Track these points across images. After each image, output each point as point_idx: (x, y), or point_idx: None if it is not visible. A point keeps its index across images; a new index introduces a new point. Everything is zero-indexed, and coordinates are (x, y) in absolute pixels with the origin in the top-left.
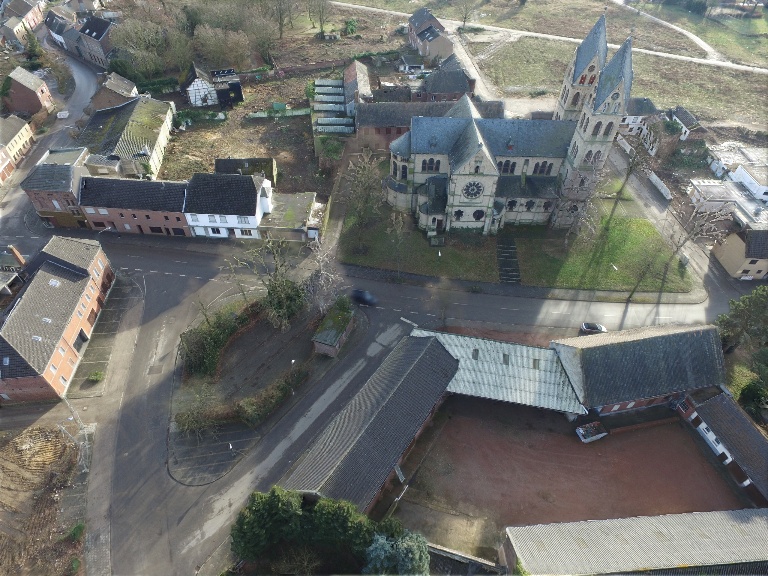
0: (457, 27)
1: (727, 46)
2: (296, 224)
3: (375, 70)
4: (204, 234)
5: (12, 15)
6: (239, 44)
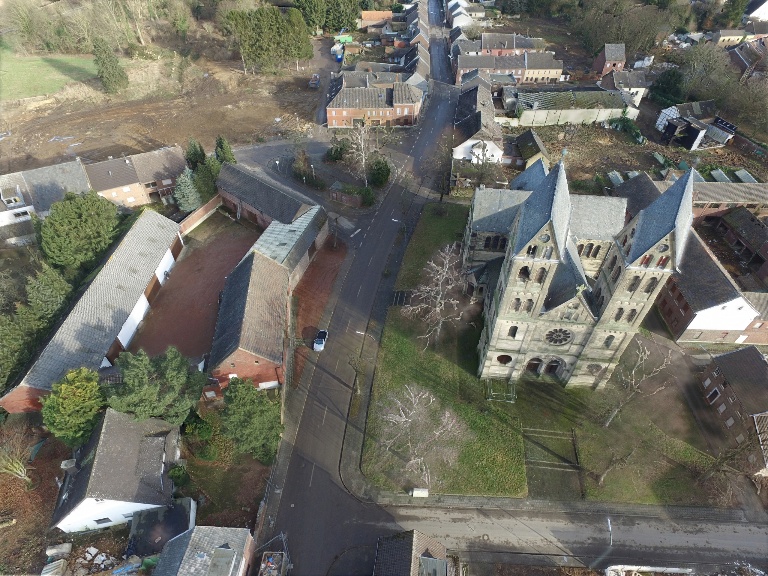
0: None
1: None
2: None
3: None
4: None
5: (750, 30)
6: None
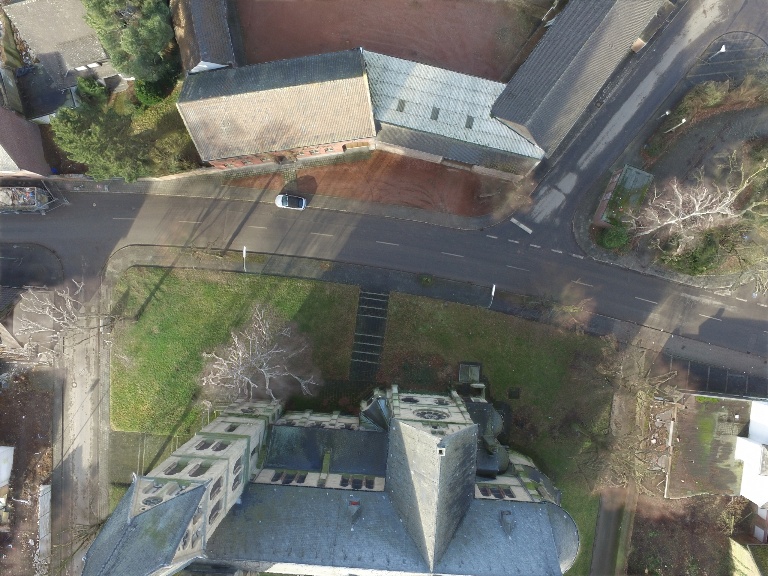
0: None
1: None
2: (694, 406)
3: None
4: None
5: None
6: None
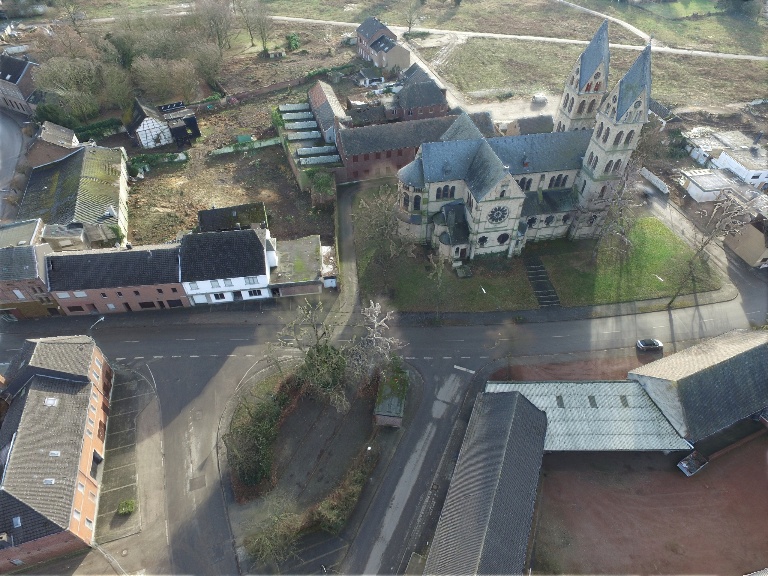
0: (402, 33)
1: (659, 31)
2: (310, 275)
3: (334, 87)
4: (205, 301)
5: None
6: (185, 74)
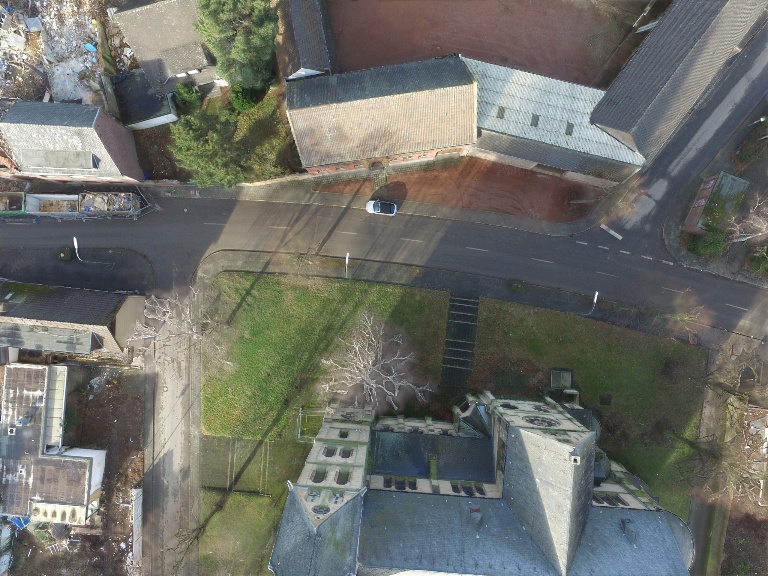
0: None
1: None
2: None
3: None
4: None
5: None
6: None
